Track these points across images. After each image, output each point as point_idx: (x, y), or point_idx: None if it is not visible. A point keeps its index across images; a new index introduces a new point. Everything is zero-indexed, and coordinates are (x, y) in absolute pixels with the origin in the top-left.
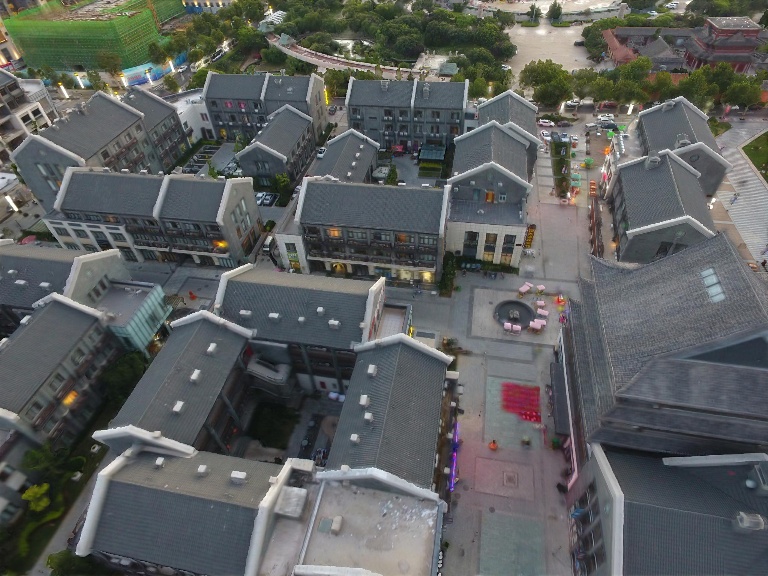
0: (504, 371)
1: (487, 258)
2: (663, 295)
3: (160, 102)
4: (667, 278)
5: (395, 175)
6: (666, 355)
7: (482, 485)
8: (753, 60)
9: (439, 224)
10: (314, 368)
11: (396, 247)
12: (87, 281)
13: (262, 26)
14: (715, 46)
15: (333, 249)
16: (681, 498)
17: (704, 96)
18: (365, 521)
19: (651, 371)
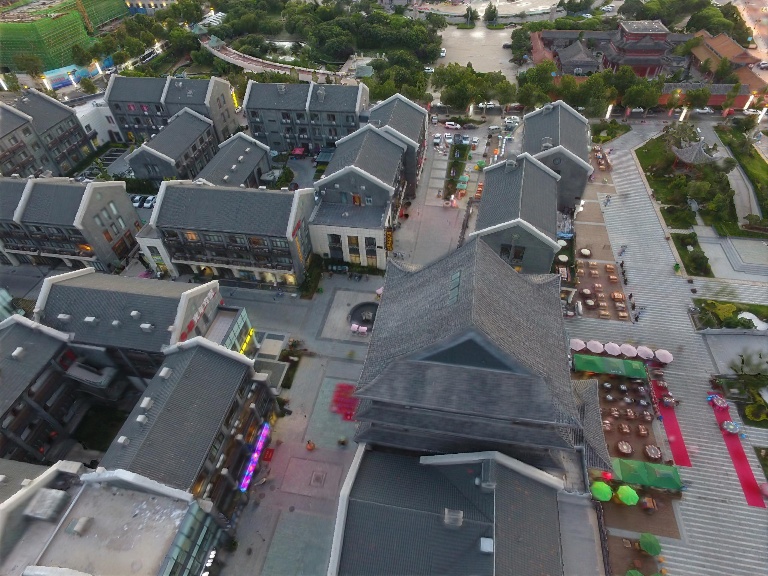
0: (342, 372)
1: (355, 260)
2: (423, 298)
3: (57, 105)
4: (431, 281)
5: (290, 178)
6: (404, 357)
7: (289, 485)
8: (662, 63)
9: (288, 227)
10: (141, 371)
11: (251, 250)
12: None
13: (196, 28)
14: (625, 49)
15: (196, 252)
16: (411, 496)
17: (600, 99)
18: (114, 522)
19: (391, 372)
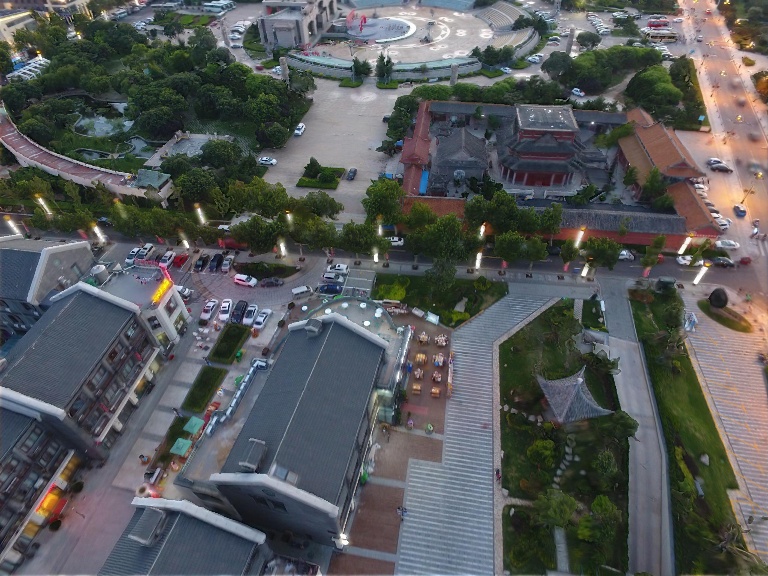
0: None
1: None
2: None
3: None
4: None
5: None
6: None
7: None
8: (570, 171)
9: None
10: None
11: None
12: None
13: None
14: (518, 151)
15: None
16: None
17: None
18: None
19: None
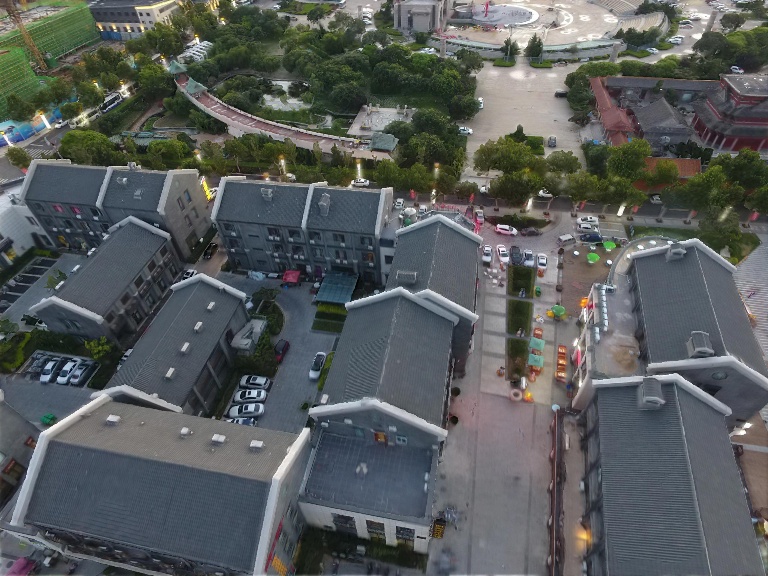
0: None
1: (377, 535)
2: None
3: None
4: None
5: (277, 328)
6: None
7: None
8: None
9: None
10: None
11: (193, 571)
12: None
13: (172, 65)
14: (735, 117)
15: None
16: None
17: None
18: None
19: None
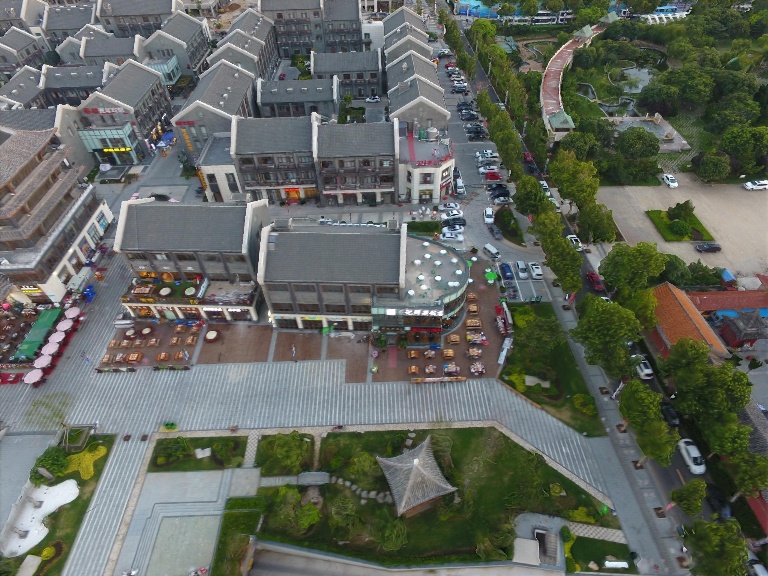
0: None
1: None
2: None
3: None
4: None
5: None
6: None
7: None
8: None
9: None
10: None
11: None
12: (159, 44)
13: None
14: None
15: None
16: None
17: None
18: None
19: None
